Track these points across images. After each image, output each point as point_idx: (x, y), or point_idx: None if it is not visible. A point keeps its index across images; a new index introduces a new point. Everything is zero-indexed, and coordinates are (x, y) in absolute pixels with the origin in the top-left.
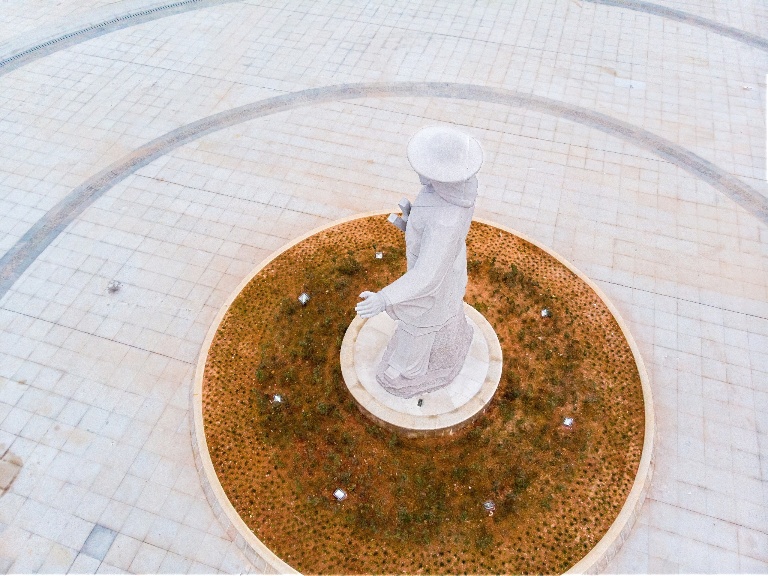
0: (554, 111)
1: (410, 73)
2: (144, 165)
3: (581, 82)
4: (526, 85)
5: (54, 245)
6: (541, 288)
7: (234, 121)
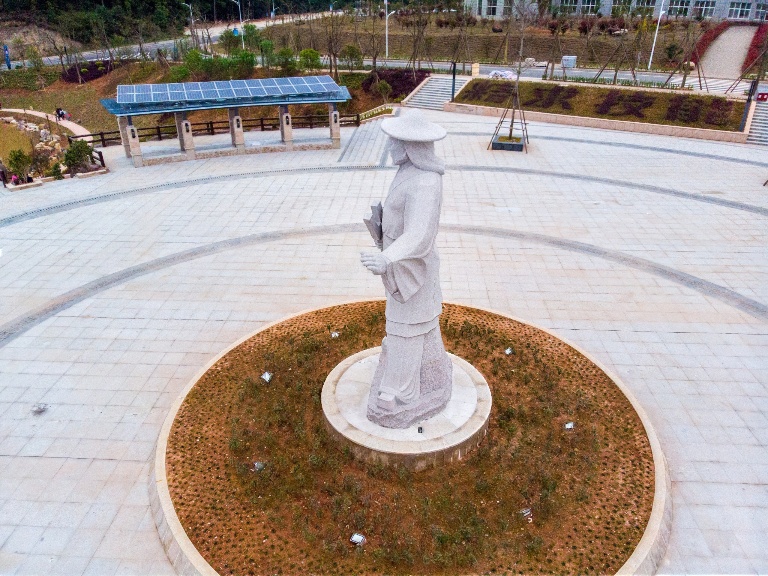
0: (455, 230)
1: (321, 221)
2: (66, 308)
3: (469, 212)
4: None
5: None
6: (497, 336)
7: (159, 267)
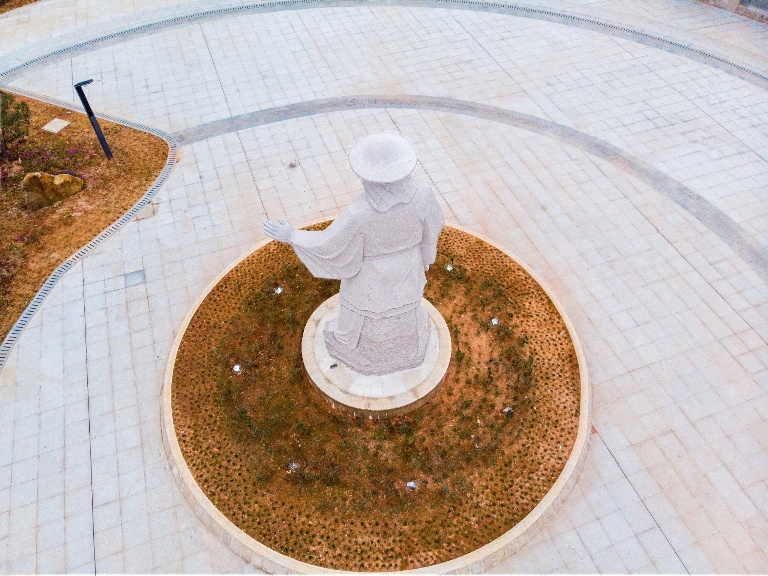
0: None
1: (677, 168)
2: (397, 107)
3: None
4: None
5: (298, 120)
6: (534, 394)
7: (487, 116)
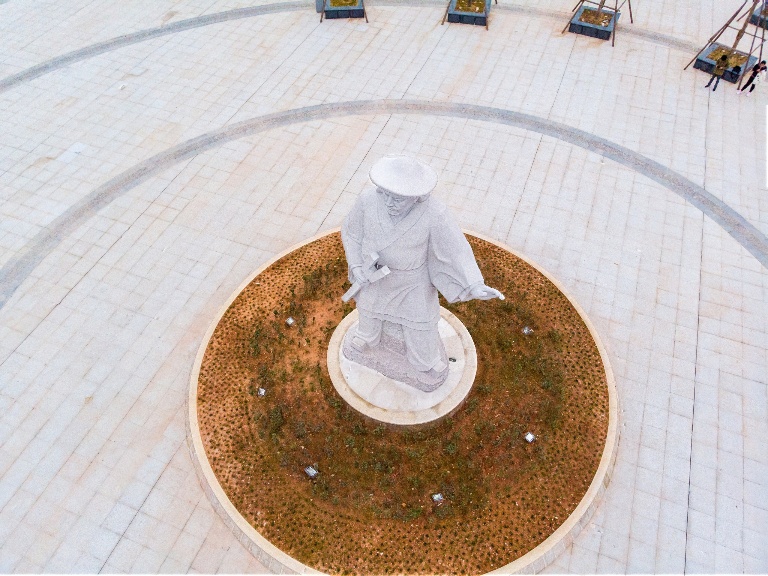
0: (84, 216)
1: None
2: None
3: (48, 186)
4: (25, 229)
5: None
6: None
7: None
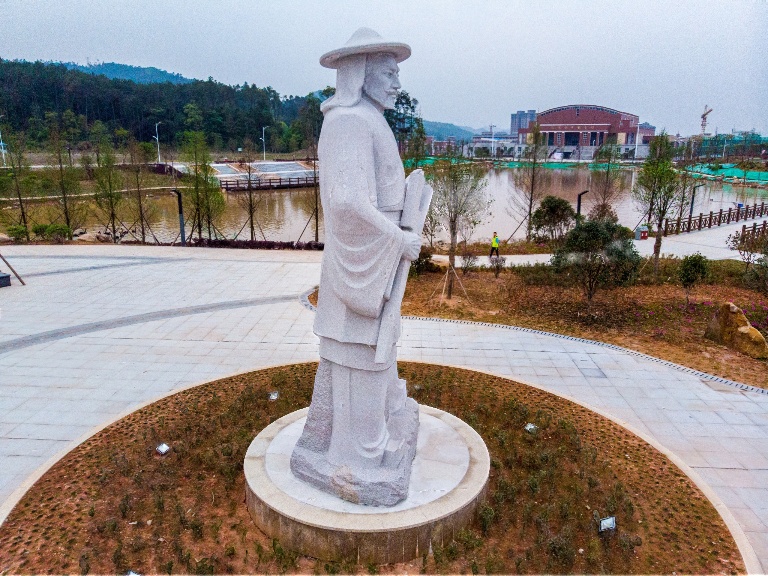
0: None
1: None
2: None
3: None
4: None
5: None
6: None
7: None
